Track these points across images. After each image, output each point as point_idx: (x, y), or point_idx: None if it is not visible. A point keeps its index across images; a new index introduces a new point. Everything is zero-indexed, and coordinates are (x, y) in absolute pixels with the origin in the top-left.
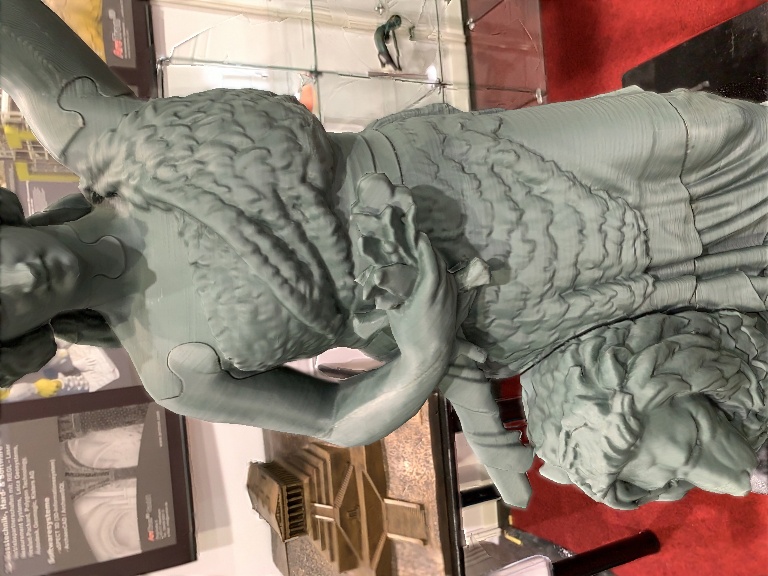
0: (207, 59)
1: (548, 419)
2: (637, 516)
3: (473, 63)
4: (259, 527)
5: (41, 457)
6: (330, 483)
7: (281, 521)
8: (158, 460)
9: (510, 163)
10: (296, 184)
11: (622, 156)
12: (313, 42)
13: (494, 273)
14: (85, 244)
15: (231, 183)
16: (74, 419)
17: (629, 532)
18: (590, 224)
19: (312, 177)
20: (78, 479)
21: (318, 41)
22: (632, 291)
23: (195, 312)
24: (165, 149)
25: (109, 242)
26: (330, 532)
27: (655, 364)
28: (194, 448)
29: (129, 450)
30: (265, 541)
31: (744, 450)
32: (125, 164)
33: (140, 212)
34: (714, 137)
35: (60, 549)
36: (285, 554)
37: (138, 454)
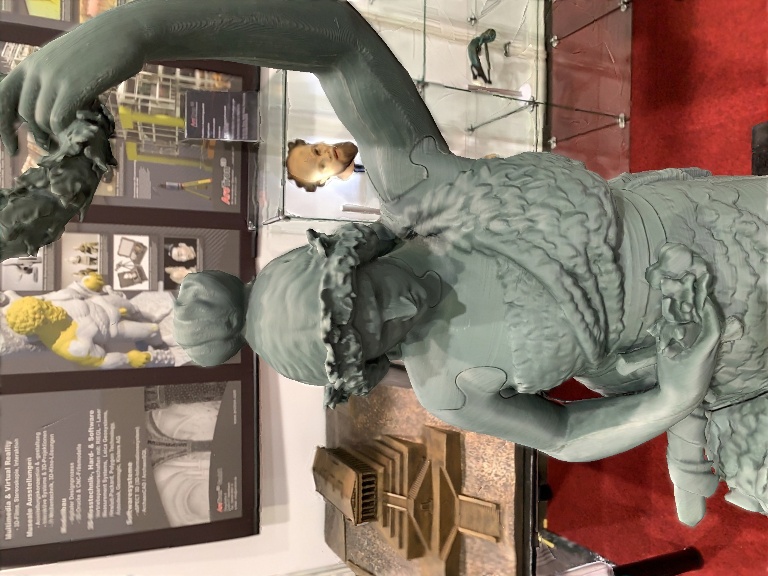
0: None
1: (746, 454)
2: (682, 533)
3: (552, 79)
4: (314, 508)
5: (128, 424)
6: (406, 475)
7: (355, 506)
8: (231, 436)
9: (751, 233)
10: (602, 244)
11: None
12: (423, 53)
13: None
14: (418, 278)
15: (556, 241)
16: (159, 391)
17: (672, 547)
18: None
19: (611, 238)
20: (159, 447)
21: (428, 52)
22: None
23: (499, 342)
24: (500, 206)
25: (433, 277)
26: (401, 521)
27: None
28: (262, 428)
29: (206, 424)
30: (317, 522)
31: None
32: (460, 214)
33: (459, 253)
34: None
35: (138, 512)
36: (343, 536)
37: (214, 429)
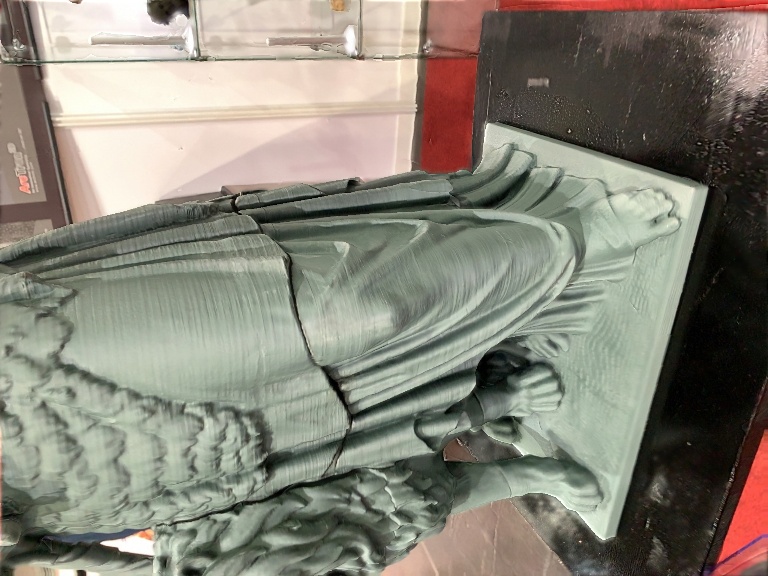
0: None
1: None
2: None
3: None
4: None
5: None
6: None
7: None
8: None
9: (63, 402)
10: None
11: (217, 382)
12: None
13: (48, 505)
14: None
15: None
16: None
17: None
18: (173, 450)
19: None
20: None
21: None
22: (232, 494)
23: None
24: None
25: None
26: None
27: None
28: None
29: None
30: None
31: None
32: None
33: None
34: (350, 350)
35: None
36: None
37: None
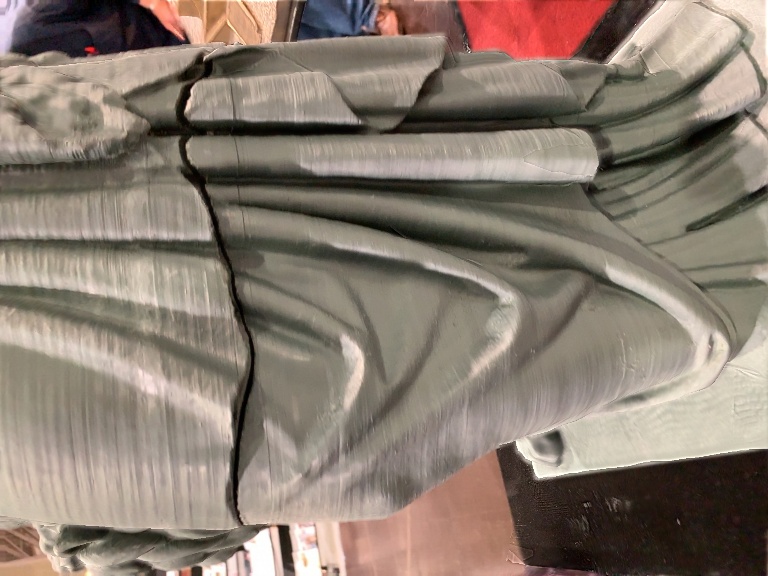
0: None
1: None
2: None
3: None
4: None
5: None
6: None
7: None
8: None
9: None
10: None
11: None
12: None
13: None
14: None
15: None
16: None
17: None
18: None
19: None
20: None
21: None
22: None
23: None
24: None
25: None
26: None
27: None
28: None
29: None
30: None
31: (213, 563)
32: None
33: None
34: None
35: None
36: None
37: None
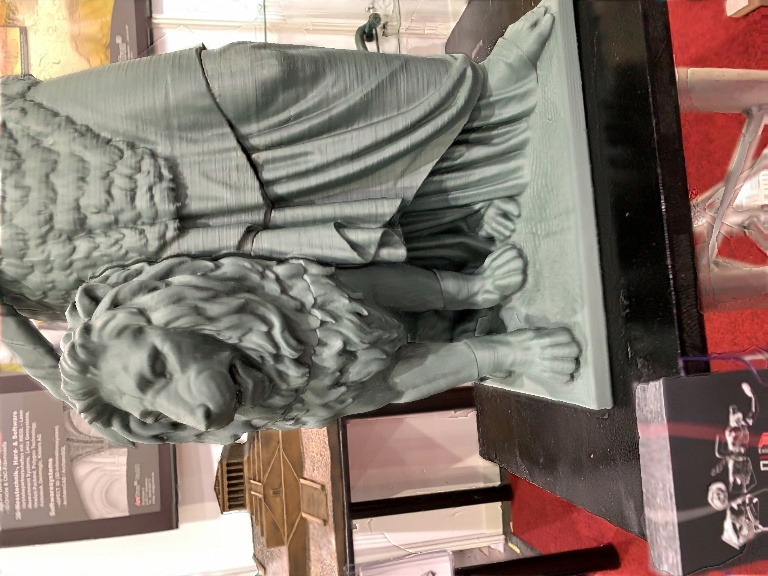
0: None
1: None
2: (603, 528)
3: None
4: None
5: (47, 423)
6: (260, 461)
7: (220, 494)
8: None
9: (17, 119)
10: None
11: (134, 108)
12: None
13: None
14: None
15: None
16: None
17: None
18: (94, 171)
19: None
20: (77, 445)
21: None
22: (143, 234)
23: None
24: None
25: None
26: (260, 508)
27: (117, 298)
28: None
29: None
30: None
31: (206, 385)
32: None
33: None
34: (243, 85)
35: (60, 504)
36: (252, 531)
37: None
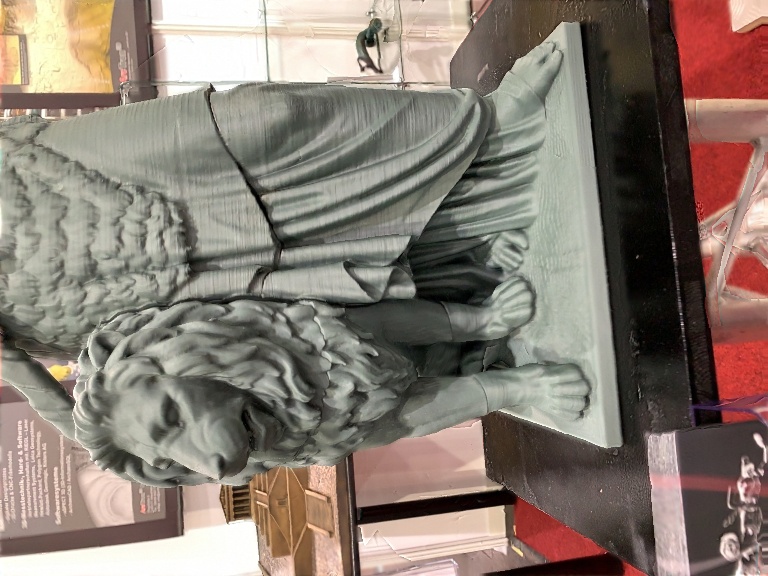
0: (163, 80)
1: None
2: None
3: None
4: None
5: (52, 432)
6: None
7: (225, 504)
8: None
9: (26, 165)
10: None
11: (143, 153)
12: (266, 54)
13: None
14: None
15: None
16: None
17: (599, 552)
18: (104, 218)
19: None
20: (82, 453)
21: (271, 53)
22: (154, 280)
23: None
24: None
25: None
26: (266, 518)
27: (129, 347)
28: None
29: None
30: None
31: (220, 434)
32: None
33: None
34: (252, 129)
35: (65, 512)
36: (257, 538)
37: None
